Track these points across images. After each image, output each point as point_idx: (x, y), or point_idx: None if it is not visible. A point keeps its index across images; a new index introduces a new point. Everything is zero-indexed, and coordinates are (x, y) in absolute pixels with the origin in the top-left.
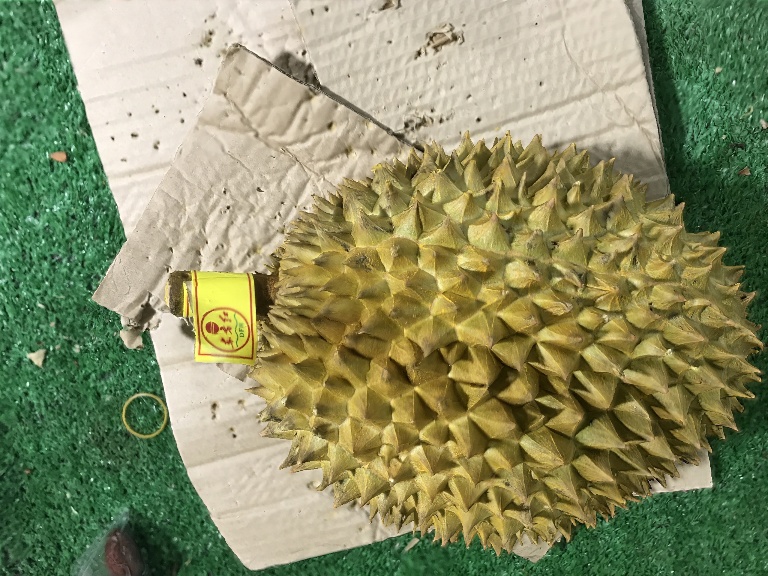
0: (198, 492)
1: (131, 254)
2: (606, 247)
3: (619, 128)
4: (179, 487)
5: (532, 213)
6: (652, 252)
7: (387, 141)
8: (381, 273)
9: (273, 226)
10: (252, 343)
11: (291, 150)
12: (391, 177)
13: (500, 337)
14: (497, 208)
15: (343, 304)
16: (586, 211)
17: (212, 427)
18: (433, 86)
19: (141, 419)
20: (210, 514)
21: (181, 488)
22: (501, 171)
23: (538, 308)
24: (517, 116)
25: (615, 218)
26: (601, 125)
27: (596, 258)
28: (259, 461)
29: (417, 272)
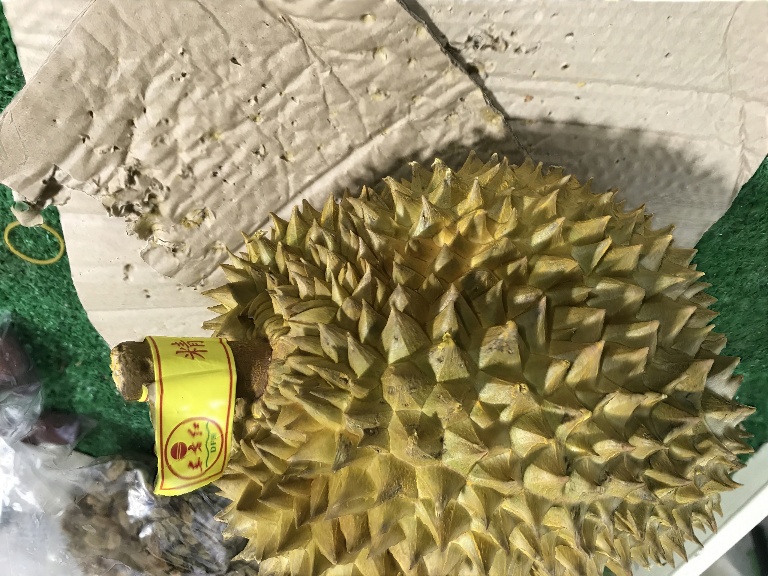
0: (98, 331)
1: (29, 113)
2: (654, 473)
3: (719, 142)
4: (73, 308)
5: (602, 442)
6: (691, 471)
7: (436, 57)
8: (412, 499)
9: (243, 110)
10: (224, 456)
11: (295, 23)
12: (460, 360)
13: (512, 573)
14: (568, 434)
15: (355, 508)
16: (657, 445)
17: (123, 287)
18: (531, 4)
19: (29, 243)
20: (109, 345)
21: (76, 308)
22: (589, 358)
23: (559, 539)
24: (614, 80)
25: (678, 434)
26: (702, 131)
27: (639, 489)
28: (172, 318)
29: (454, 512)
